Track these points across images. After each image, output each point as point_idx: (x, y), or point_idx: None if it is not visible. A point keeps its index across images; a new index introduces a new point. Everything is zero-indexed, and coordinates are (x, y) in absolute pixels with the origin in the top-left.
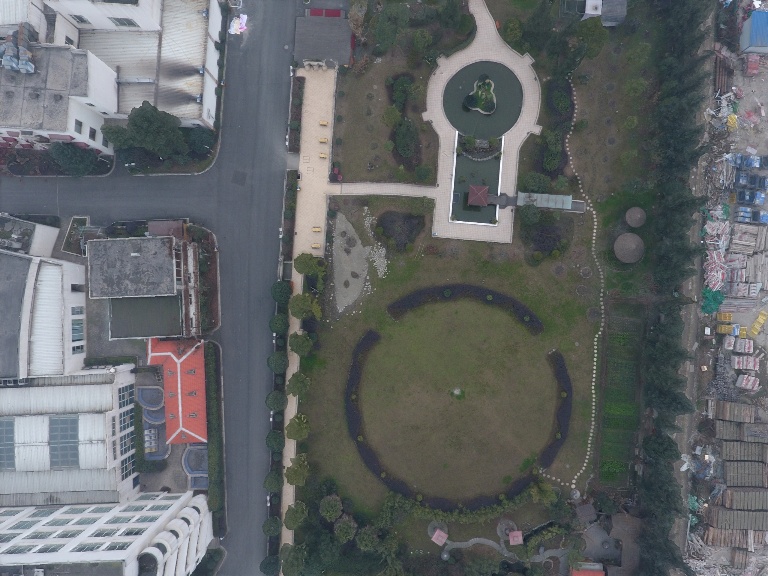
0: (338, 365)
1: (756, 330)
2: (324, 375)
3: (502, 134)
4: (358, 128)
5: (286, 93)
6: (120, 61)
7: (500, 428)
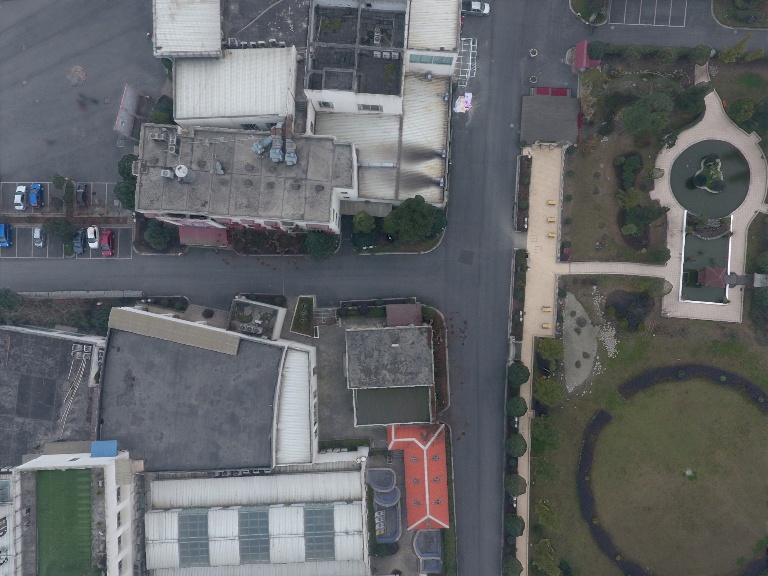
0: (569, 446)
1: None
2: (555, 456)
3: (730, 213)
4: (585, 207)
5: (512, 171)
6: (359, 144)
7: (733, 509)
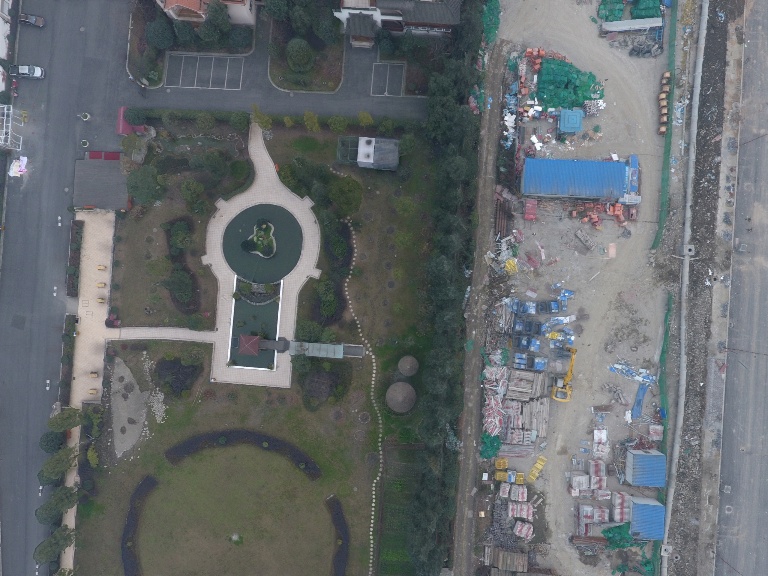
0: (116, 511)
1: (534, 475)
2: (102, 521)
3: (282, 278)
4: (137, 272)
5: (66, 236)
6: None
7: (278, 574)
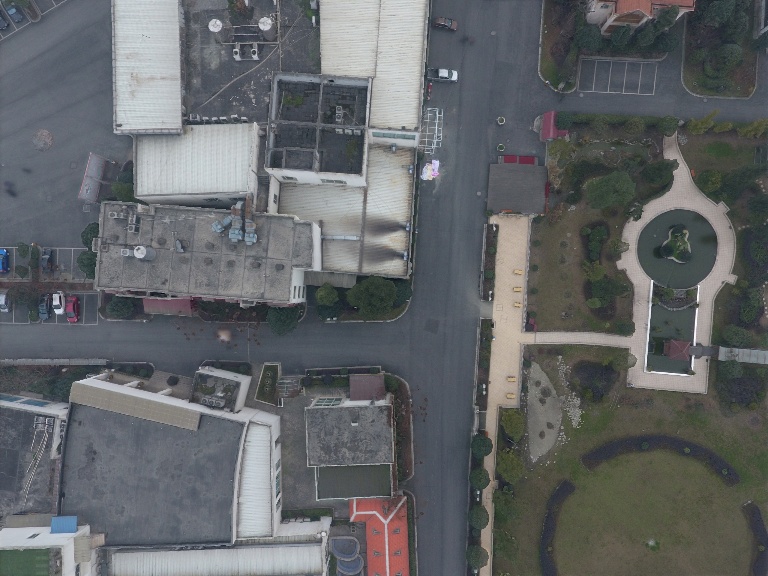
0: (532, 515)
1: None
2: (518, 525)
3: (697, 283)
4: (552, 276)
5: (479, 240)
6: (323, 216)
7: None
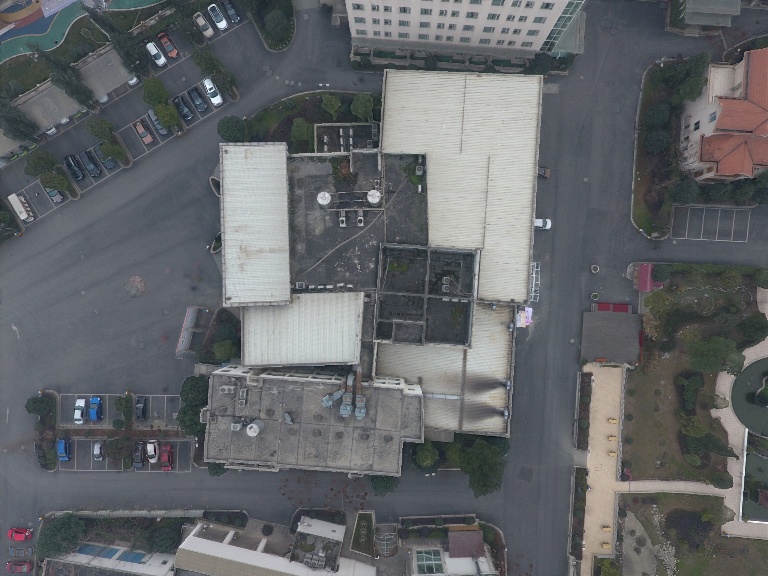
0: None
1: None
2: None
3: None
4: (646, 424)
5: (572, 387)
6: (422, 372)
7: None
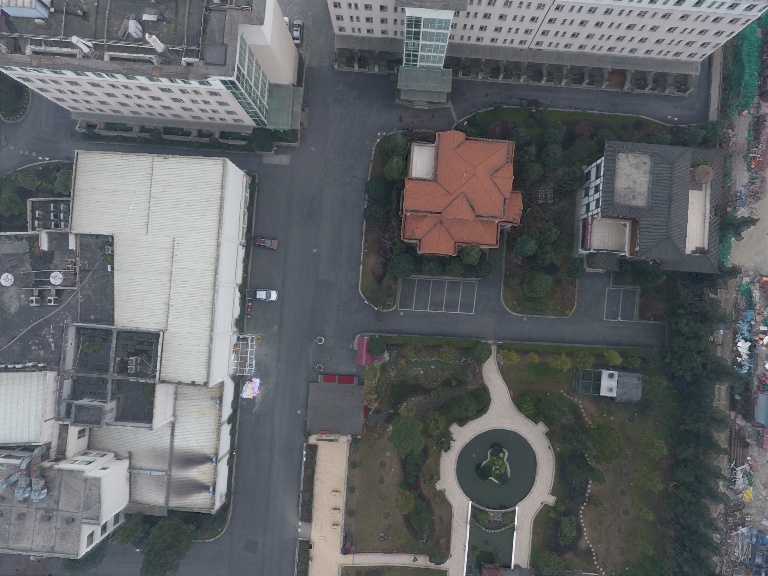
0: None
1: None
2: None
3: (516, 504)
4: (371, 496)
5: (298, 459)
6: (132, 447)
7: None
